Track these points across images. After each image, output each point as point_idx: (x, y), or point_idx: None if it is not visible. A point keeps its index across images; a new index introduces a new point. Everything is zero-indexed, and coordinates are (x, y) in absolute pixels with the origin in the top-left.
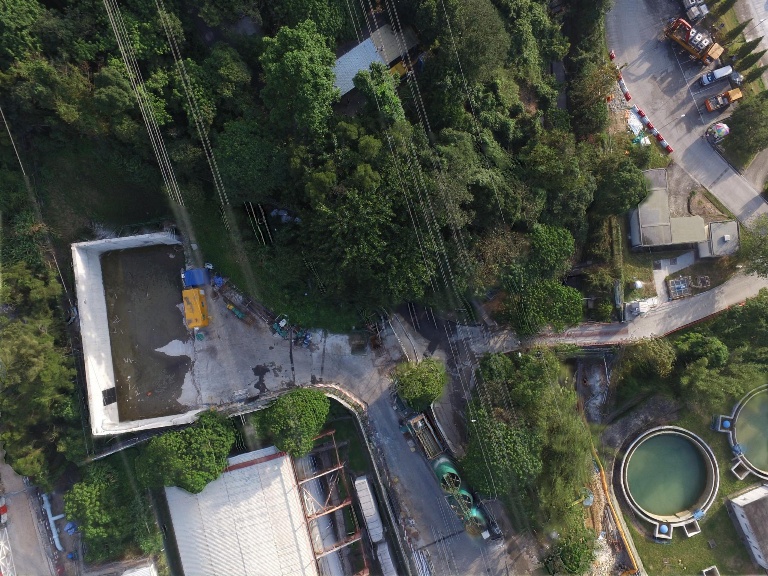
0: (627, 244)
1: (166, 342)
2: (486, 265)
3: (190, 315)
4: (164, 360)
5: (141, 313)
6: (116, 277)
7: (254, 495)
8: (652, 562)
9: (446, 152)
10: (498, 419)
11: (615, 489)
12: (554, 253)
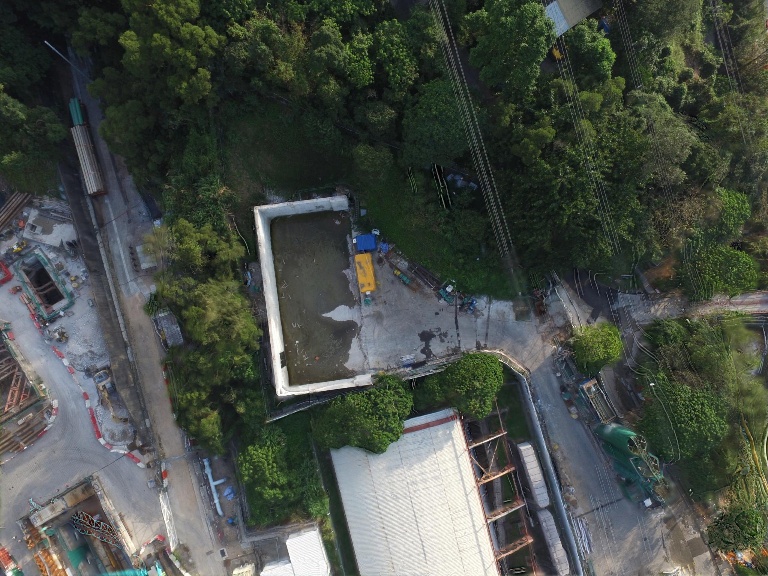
0: None
1: (333, 307)
2: (667, 228)
3: (363, 279)
4: (331, 325)
5: (308, 278)
6: (283, 243)
7: (427, 458)
8: None
9: (641, 112)
10: (681, 382)
11: None
12: (732, 217)
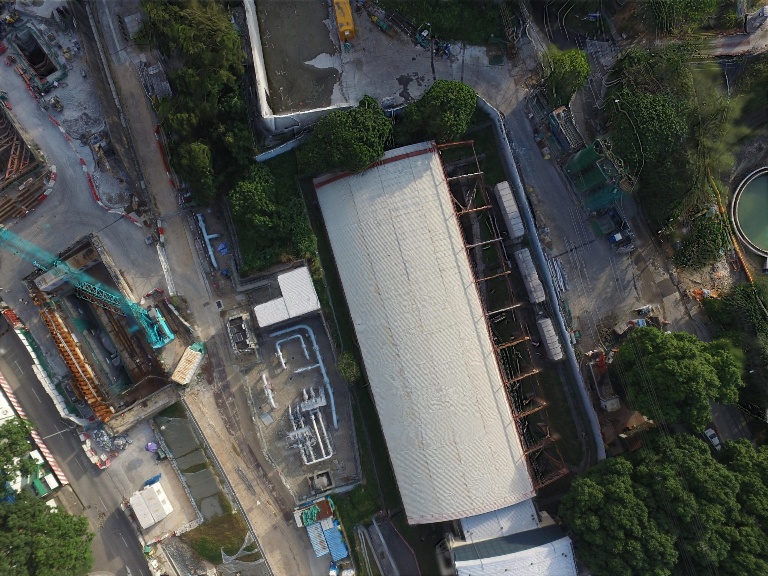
0: None
1: (314, 55)
2: None
3: (341, 19)
4: (313, 72)
5: (290, 29)
6: None
7: (407, 186)
8: (762, 294)
9: None
10: (644, 91)
11: None
12: None
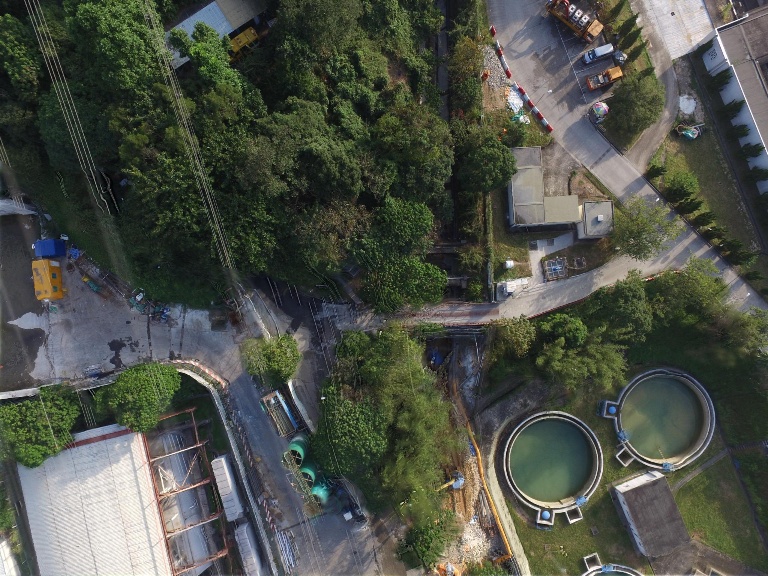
0: (504, 224)
1: (20, 314)
2: (336, 239)
3: (39, 286)
4: (17, 333)
5: None
6: None
7: (102, 471)
8: (533, 548)
9: (284, 120)
10: (344, 396)
11: (498, 474)
12: (409, 228)
